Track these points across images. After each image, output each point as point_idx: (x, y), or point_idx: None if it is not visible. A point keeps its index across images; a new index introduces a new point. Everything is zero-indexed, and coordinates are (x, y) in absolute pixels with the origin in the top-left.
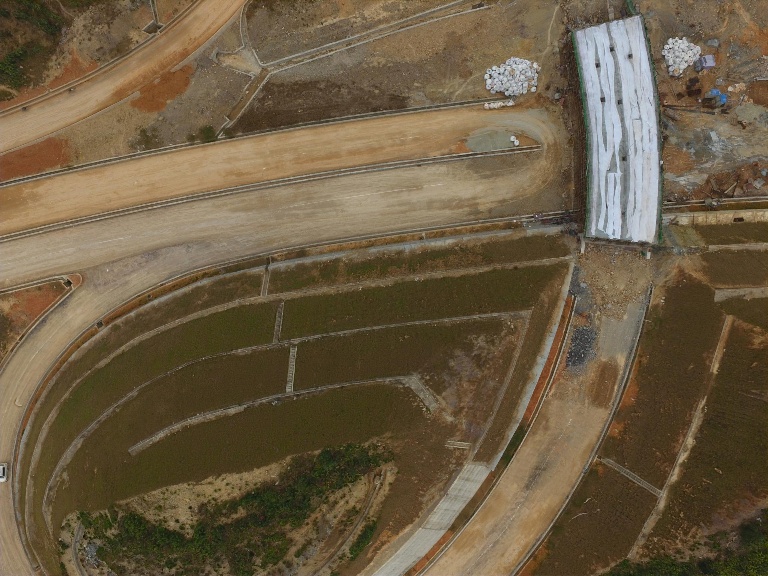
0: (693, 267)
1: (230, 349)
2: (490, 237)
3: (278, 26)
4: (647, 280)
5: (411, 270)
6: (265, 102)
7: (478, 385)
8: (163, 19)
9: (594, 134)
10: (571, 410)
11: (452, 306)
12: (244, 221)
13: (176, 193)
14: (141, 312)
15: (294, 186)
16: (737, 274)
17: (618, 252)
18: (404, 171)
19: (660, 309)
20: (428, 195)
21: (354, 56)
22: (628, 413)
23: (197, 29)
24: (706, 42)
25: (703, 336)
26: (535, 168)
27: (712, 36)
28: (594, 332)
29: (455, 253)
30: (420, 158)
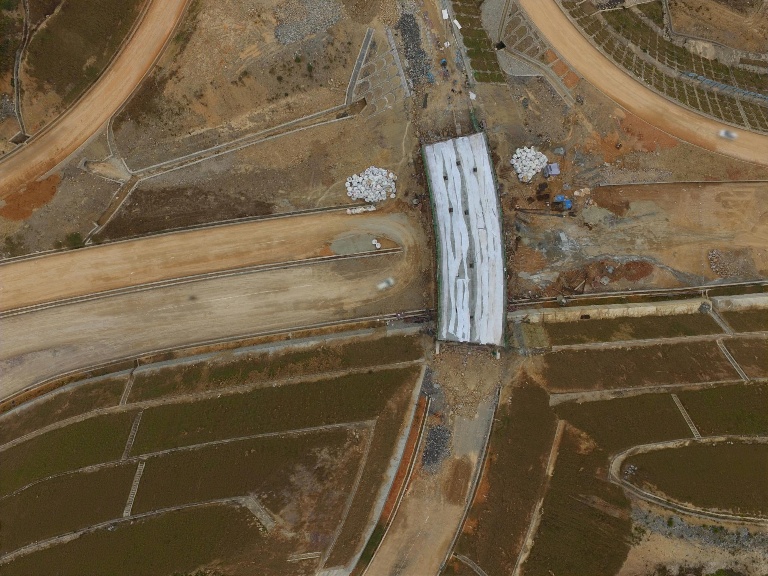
0: (534, 370)
1: (78, 467)
2: (352, 338)
3: (146, 136)
4: (494, 381)
5: (270, 375)
6: (132, 209)
7: (319, 499)
8: (30, 130)
9: (443, 242)
10: (428, 508)
11: (302, 416)
12: (112, 325)
13: (43, 298)
14: (2, 420)
15: (162, 290)
16: (572, 377)
17: (471, 352)
18: (271, 273)
19: (508, 408)
20: (294, 296)
21: (222, 163)
22: (481, 510)
23: (64, 140)
24: (553, 150)
25: (540, 439)
26: (397, 269)
27: (558, 145)
28: (448, 431)
29: (317, 355)
30: (286, 261)
